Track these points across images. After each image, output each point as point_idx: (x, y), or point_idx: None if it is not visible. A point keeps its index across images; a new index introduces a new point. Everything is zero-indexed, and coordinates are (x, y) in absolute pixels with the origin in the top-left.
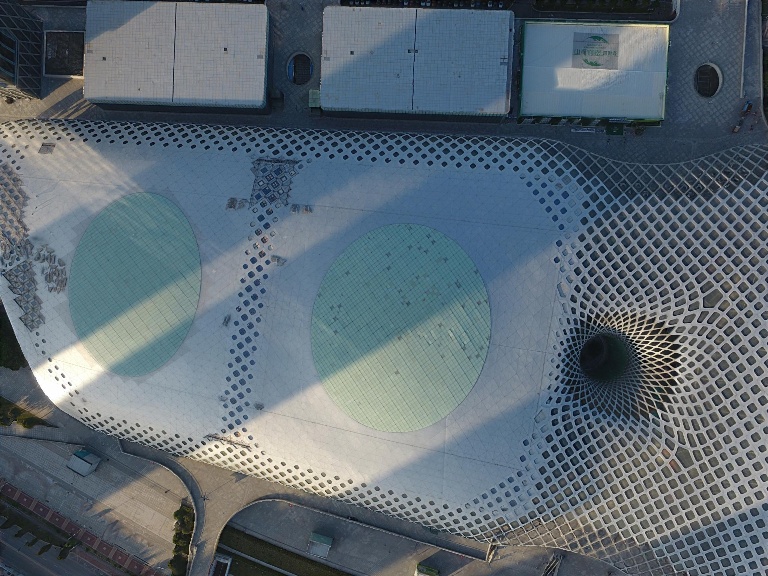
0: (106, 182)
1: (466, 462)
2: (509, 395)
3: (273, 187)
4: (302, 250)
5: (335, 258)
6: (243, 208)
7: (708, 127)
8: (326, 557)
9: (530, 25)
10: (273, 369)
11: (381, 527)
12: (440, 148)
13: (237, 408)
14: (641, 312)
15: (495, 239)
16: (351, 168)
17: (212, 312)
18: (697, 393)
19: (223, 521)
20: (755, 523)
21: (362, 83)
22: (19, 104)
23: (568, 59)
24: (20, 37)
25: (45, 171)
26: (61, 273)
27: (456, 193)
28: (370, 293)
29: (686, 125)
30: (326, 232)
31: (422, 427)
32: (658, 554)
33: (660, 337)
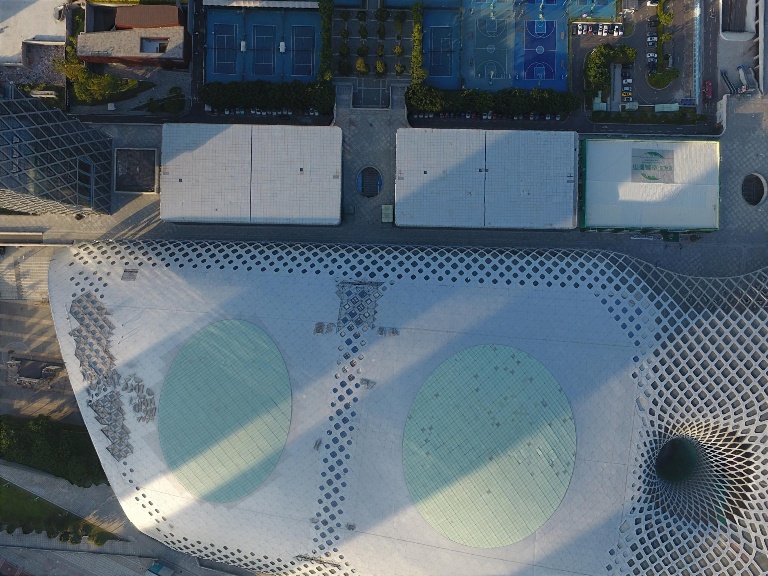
0: (193, 309)
1: (555, 573)
2: (595, 507)
3: (359, 310)
4: (391, 373)
5: (424, 380)
6: (331, 332)
7: (756, 233)
8: None
9: (591, 142)
10: (365, 490)
11: None
12: (516, 266)
13: (328, 529)
14: (715, 422)
15: (576, 357)
16: (433, 289)
17: (303, 437)
18: None
19: None
20: None
21: (436, 201)
22: (88, 220)
23: (628, 174)
24: (95, 160)
25: (129, 299)
26: (150, 403)
27: (536, 312)
28: (460, 415)
29: (736, 231)
30: (413, 354)
31: (513, 542)
32: None
33: (733, 445)
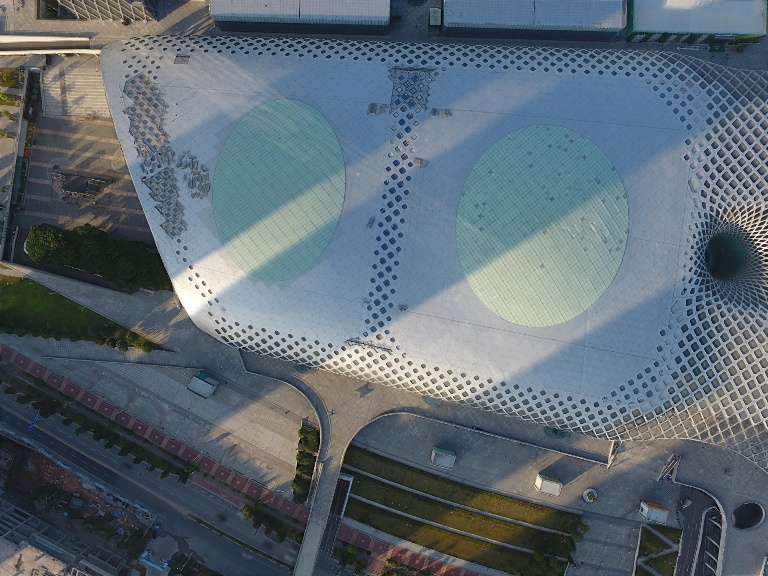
0: (246, 90)
1: (605, 354)
2: (647, 287)
3: (411, 93)
4: (444, 152)
5: (477, 158)
6: (384, 113)
7: None
8: (452, 468)
9: None
10: (417, 269)
11: (505, 436)
12: (567, 57)
13: (381, 310)
14: (766, 205)
15: (628, 139)
16: (485, 75)
17: (357, 214)
18: None
19: (349, 437)
20: None
21: None
22: (135, 26)
23: None
24: None
25: (183, 80)
26: (204, 179)
27: (588, 97)
28: (514, 190)
29: None
30: (466, 134)
31: (565, 320)
32: None
33: None
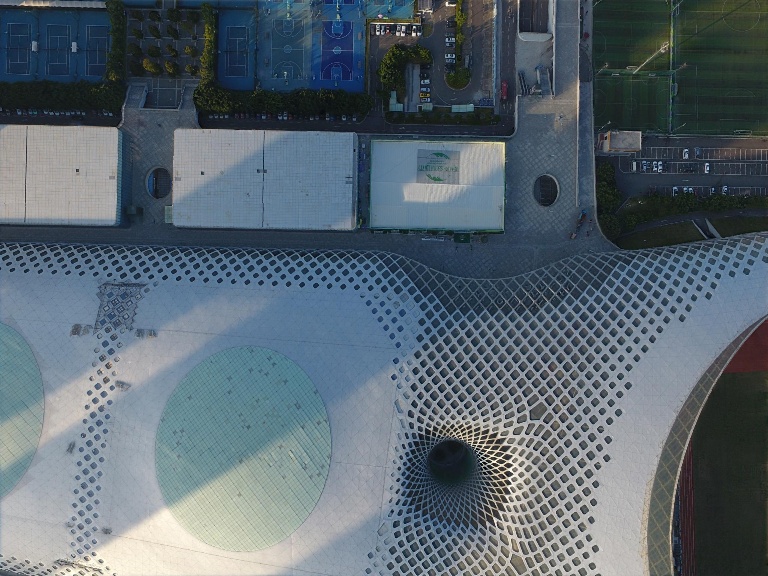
0: None
1: None
2: (352, 510)
3: (118, 312)
4: (146, 375)
5: (178, 383)
6: (87, 334)
7: (548, 234)
8: None
9: (376, 142)
10: (119, 494)
11: None
12: (286, 267)
13: (85, 533)
14: (475, 424)
15: (335, 359)
16: (197, 291)
17: (56, 440)
18: (527, 502)
19: None
20: None
21: (213, 202)
22: None
23: (413, 175)
24: None
25: None
26: None
27: (298, 314)
28: (211, 418)
29: (528, 232)
30: (170, 356)
31: (268, 546)
32: None
33: (495, 447)
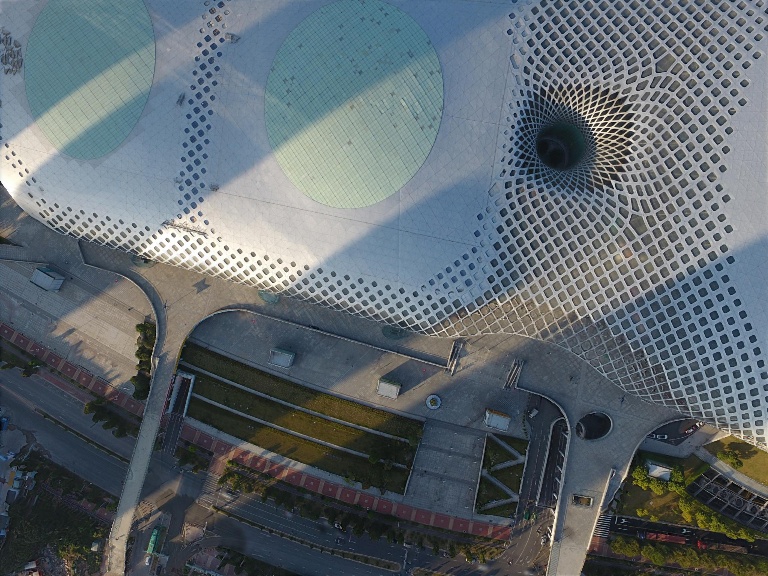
0: None
1: (421, 239)
2: (463, 168)
3: None
4: (256, 27)
5: (288, 33)
6: None
7: None
8: (288, 367)
9: None
10: (227, 147)
11: (342, 335)
12: None
13: (192, 190)
14: (595, 83)
15: (448, 13)
16: None
17: (166, 90)
18: (650, 158)
19: (185, 332)
20: (709, 286)
21: None
22: None
23: None
24: None
25: None
26: (17, 54)
27: None
28: (322, 63)
29: None
30: (280, 9)
31: (376, 202)
32: (614, 332)
33: (614, 110)
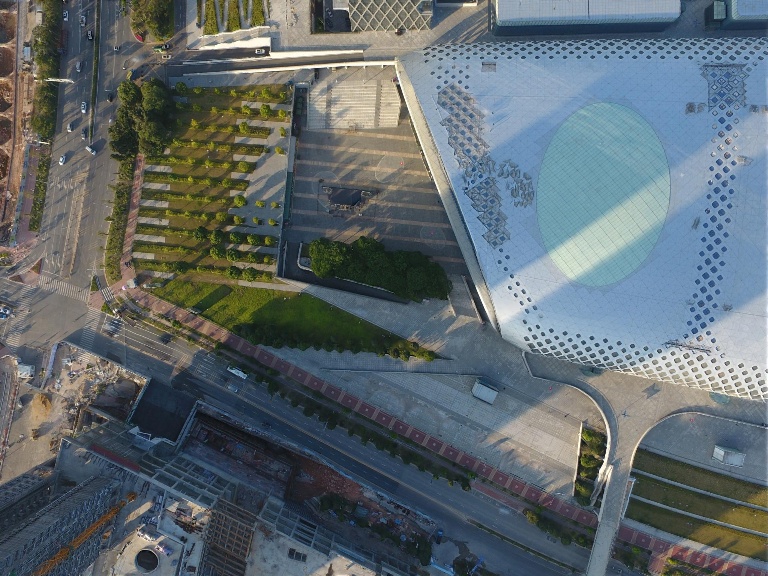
0: (561, 95)
1: None
2: None
3: (727, 90)
4: (767, 149)
5: None
6: (703, 112)
7: None
8: (742, 466)
9: None
10: (744, 268)
11: None
12: None
13: (704, 311)
14: None
15: None
16: None
17: (682, 216)
18: None
19: (637, 438)
20: None
21: None
22: (408, 36)
23: None
24: None
25: (495, 89)
26: (527, 187)
27: None
28: None
29: None
30: None
31: None
32: None
33: None
